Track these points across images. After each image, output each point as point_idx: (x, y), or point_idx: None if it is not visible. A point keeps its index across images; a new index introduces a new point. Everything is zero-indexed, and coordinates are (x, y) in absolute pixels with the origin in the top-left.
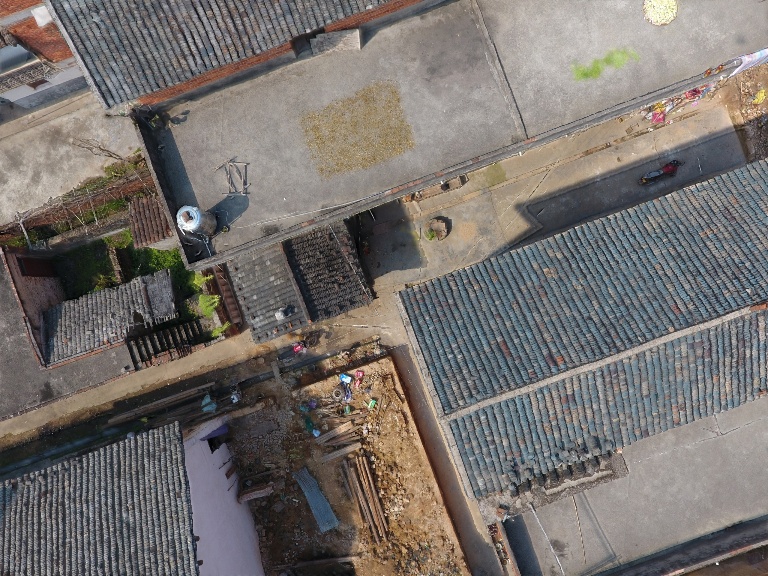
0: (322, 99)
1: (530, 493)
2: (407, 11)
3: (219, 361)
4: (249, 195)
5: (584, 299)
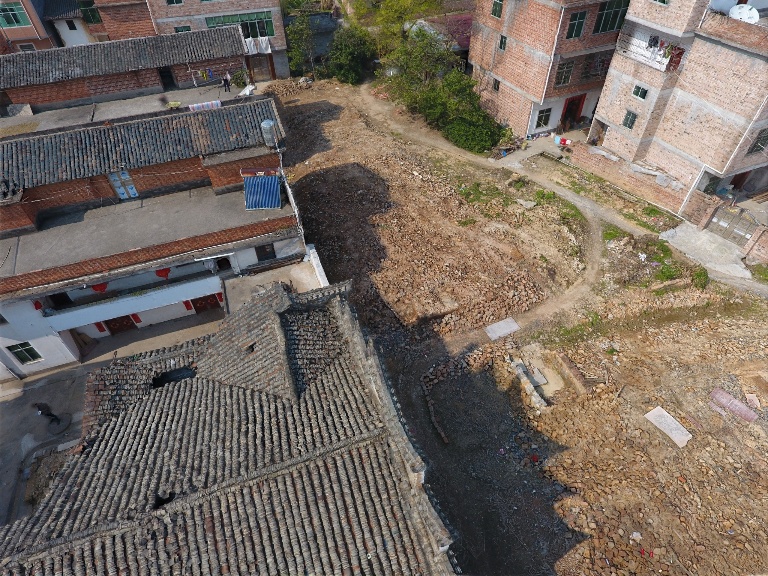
0: (2, 126)
1: None
2: (60, 104)
3: None
4: None
5: None
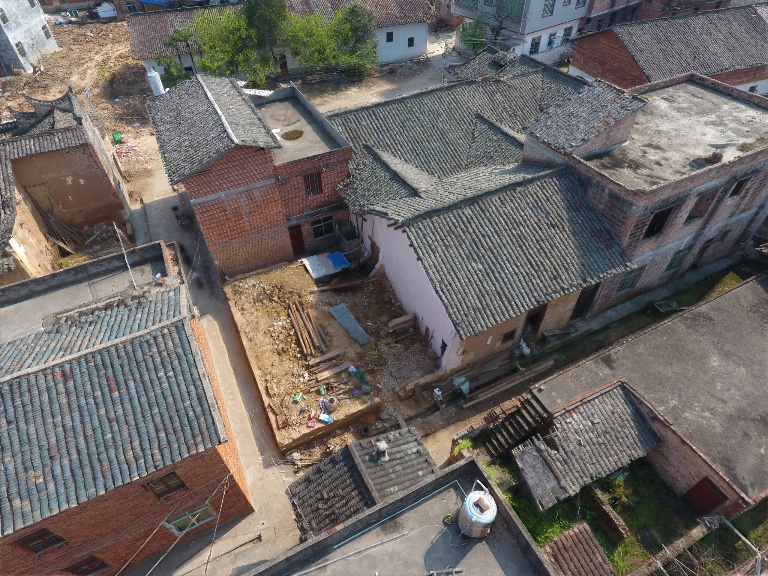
0: None
1: None
2: None
3: (465, 428)
4: (426, 574)
5: (7, 445)
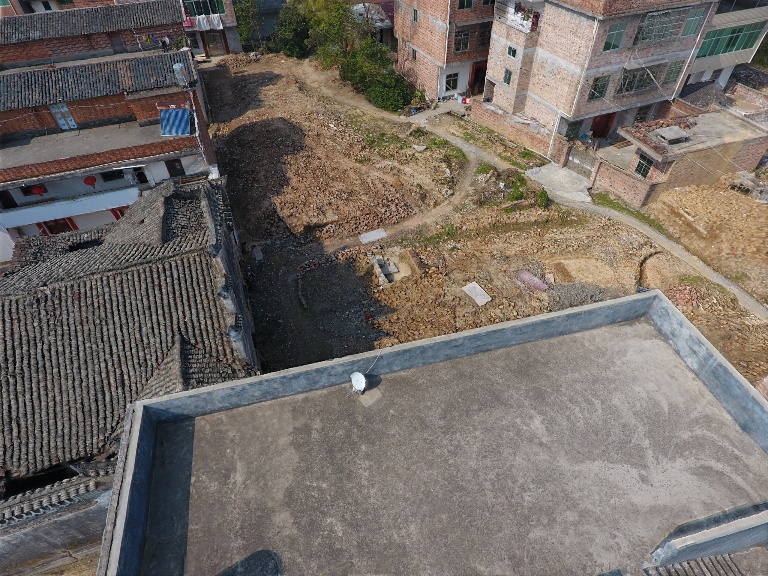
0: None
1: None
2: (23, 63)
3: None
4: None
5: None
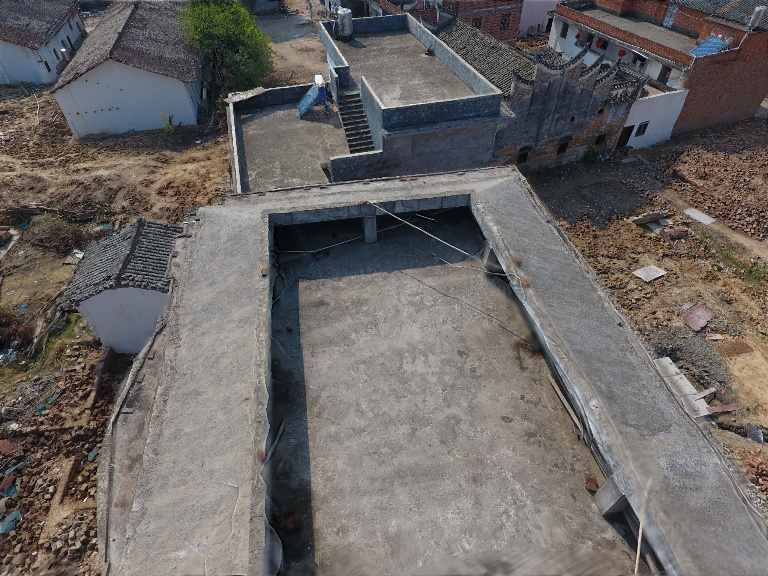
0: None
1: None
2: None
3: None
4: None
5: None
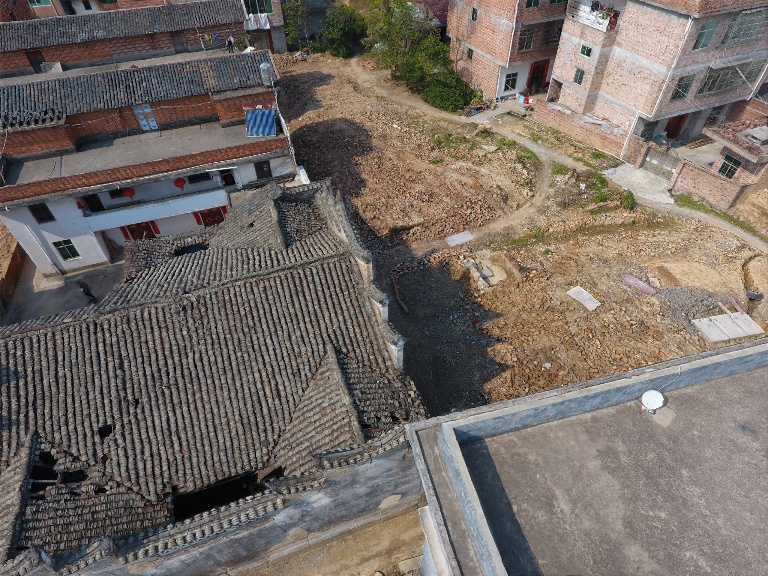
0: None
1: (11, 128)
2: (86, 63)
3: None
4: None
5: None
